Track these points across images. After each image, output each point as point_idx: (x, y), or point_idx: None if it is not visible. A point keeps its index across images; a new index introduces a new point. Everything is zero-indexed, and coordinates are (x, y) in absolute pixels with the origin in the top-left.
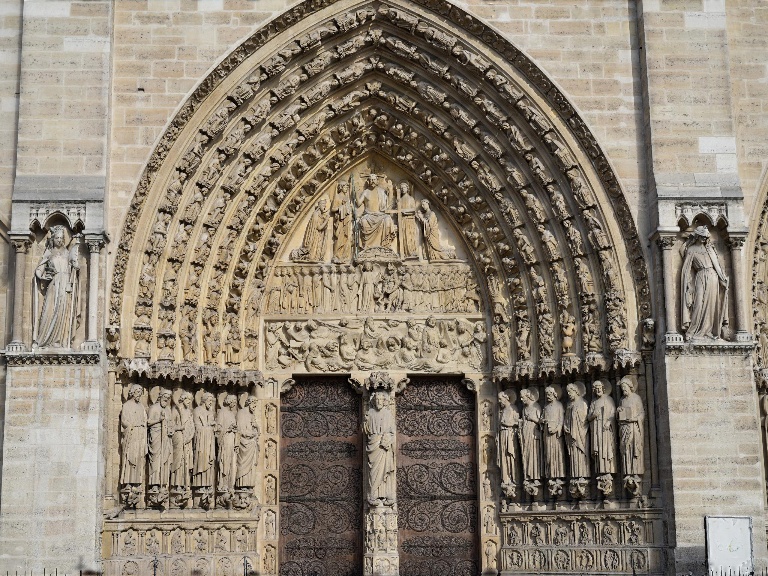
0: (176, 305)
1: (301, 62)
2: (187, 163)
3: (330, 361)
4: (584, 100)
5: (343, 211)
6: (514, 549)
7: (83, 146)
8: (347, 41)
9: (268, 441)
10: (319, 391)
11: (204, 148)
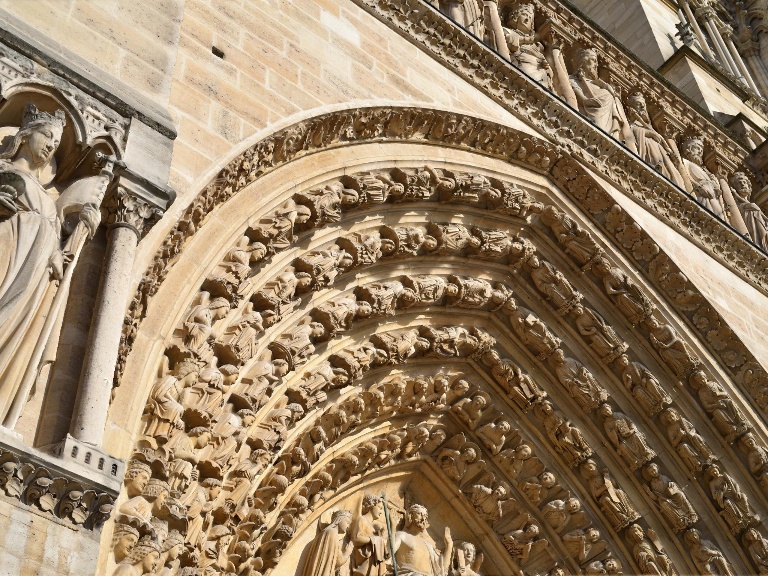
0: None
1: (431, 215)
2: (274, 230)
3: None
4: None
5: (380, 546)
6: None
7: (121, 31)
8: None
9: None
10: None
11: None
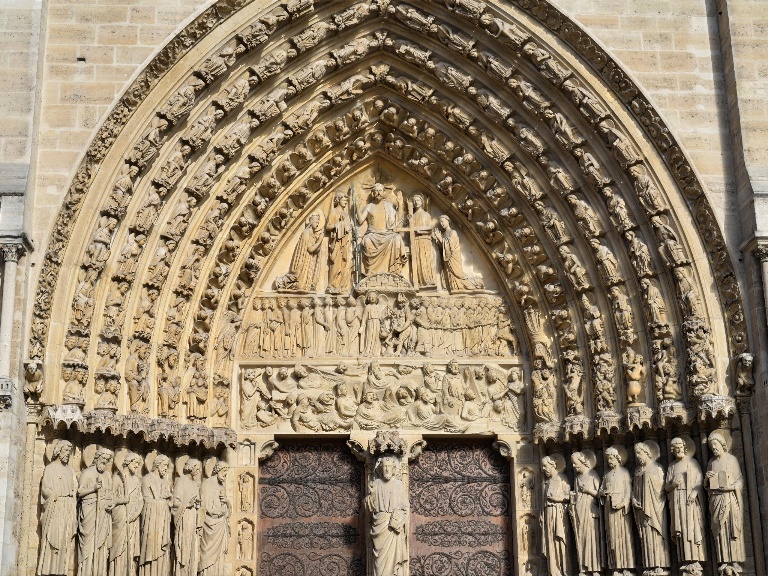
0: (122, 338)
1: (288, 34)
2: (139, 153)
3: (323, 417)
4: (650, 77)
5: (341, 229)
6: None
7: (1, 126)
8: (347, 9)
9: (242, 522)
10: (309, 458)
11: (162, 137)
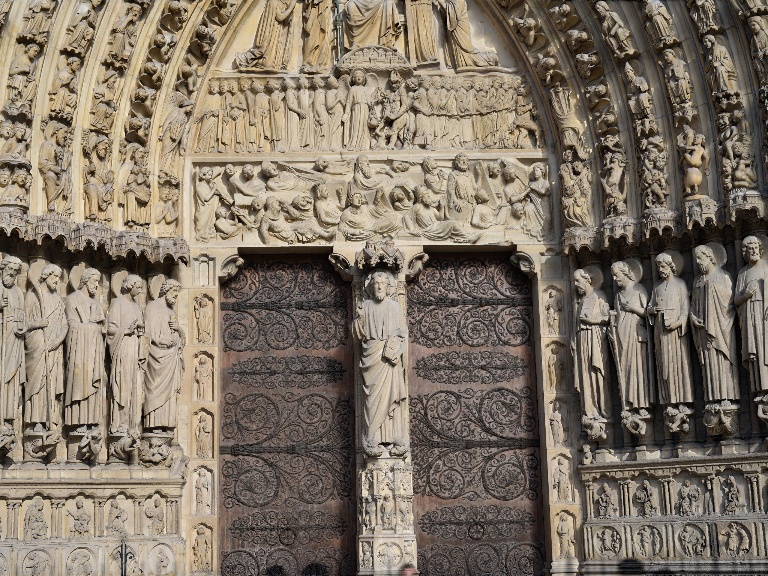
0: (32, 117)
1: None
2: None
3: (299, 226)
4: None
5: None
6: (606, 524)
7: None
8: None
9: (199, 355)
10: (282, 277)
11: None
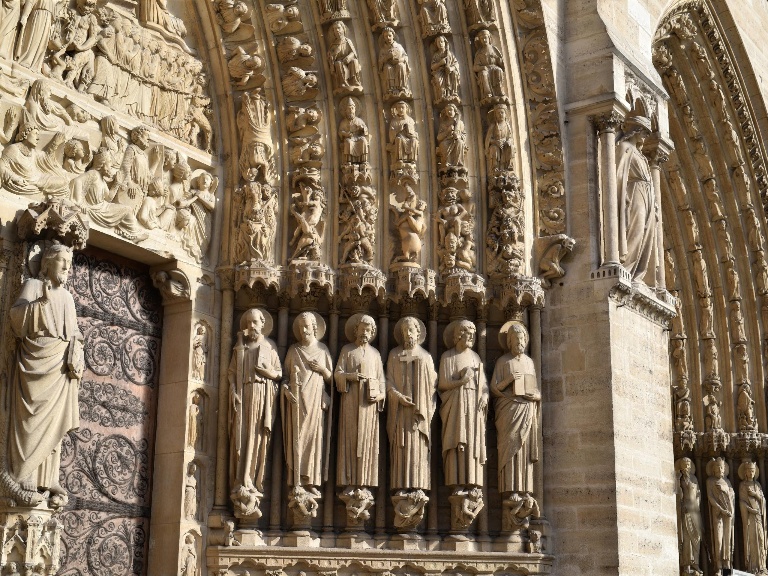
0: None
1: None
2: None
3: None
4: None
5: None
6: None
7: None
8: None
9: None
10: None
11: None
